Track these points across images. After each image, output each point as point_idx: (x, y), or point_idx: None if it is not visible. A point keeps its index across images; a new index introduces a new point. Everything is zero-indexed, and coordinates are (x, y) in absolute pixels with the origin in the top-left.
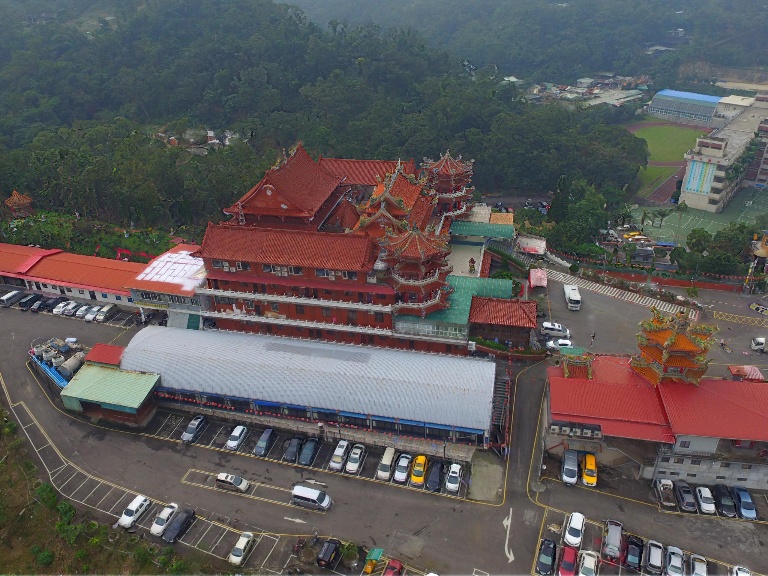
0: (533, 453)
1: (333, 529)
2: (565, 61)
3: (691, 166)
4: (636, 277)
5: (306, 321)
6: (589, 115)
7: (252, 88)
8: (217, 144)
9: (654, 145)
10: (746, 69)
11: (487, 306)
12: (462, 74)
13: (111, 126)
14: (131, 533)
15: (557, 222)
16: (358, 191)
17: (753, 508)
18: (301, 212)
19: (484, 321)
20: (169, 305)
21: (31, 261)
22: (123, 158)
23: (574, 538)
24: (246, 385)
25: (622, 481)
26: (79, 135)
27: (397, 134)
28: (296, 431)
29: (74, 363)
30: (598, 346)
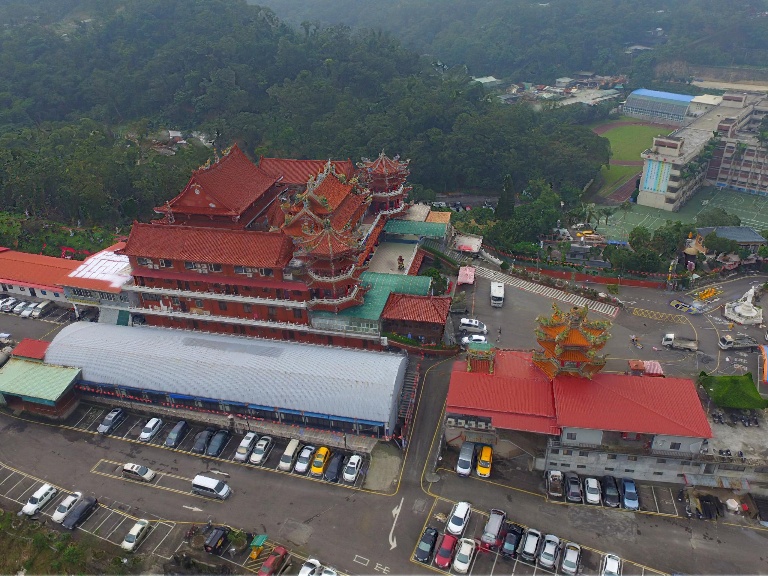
0: (432, 445)
1: (228, 517)
2: (544, 61)
3: (648, 165)
4: (567, 275)
5: (228, 317)
6: (561, 115)
7: (221, 89)
8: (185, 144)
9: (624, 144)
10: (722, 68)
11: (400, 302)
12: (432, 74)
13: (77, 127)
14: (34, 520)
15: (503, 221)
16: (293, 190)
17: (636, 498)
18: (228, 211)
19: (396, 317)
20: (100, 301)
21: None
22: (73, 158)
23: (456, 526)
24: (161, 379)
25: (516, 472)
26: (46, 136)
27: (360, 134)
28: (209, 423)
29: (0, 357)
30: (513, 342)
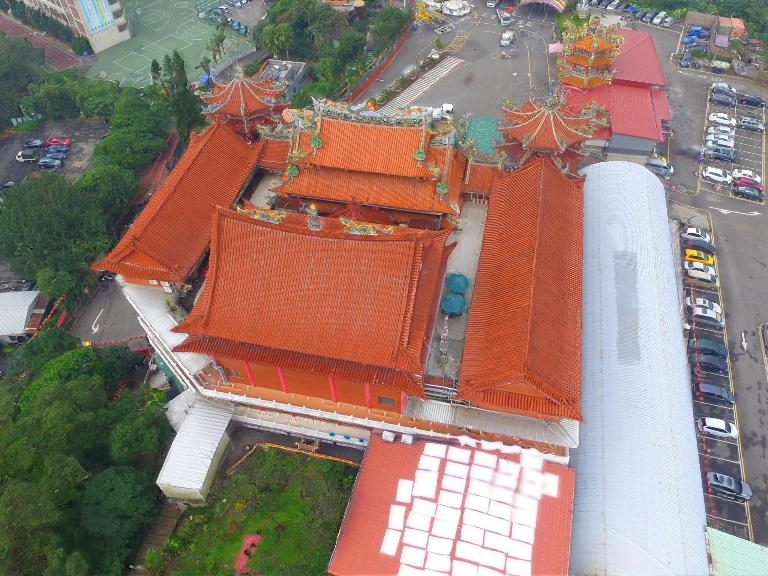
0: None
1: None
2: None
3: (79, 1)
4: (370, 79)
5: None
6: None
7: None
8: None
9: None
10: None
11: None
12: None
13: None
14: None
15: None
16: (287, 202)
17: None
18: (433, 247)
19: None
20: None
21: None
22: None
23: (729, 176)
24: None
25: None
26: None
27: None
28: None
29: None
30: None
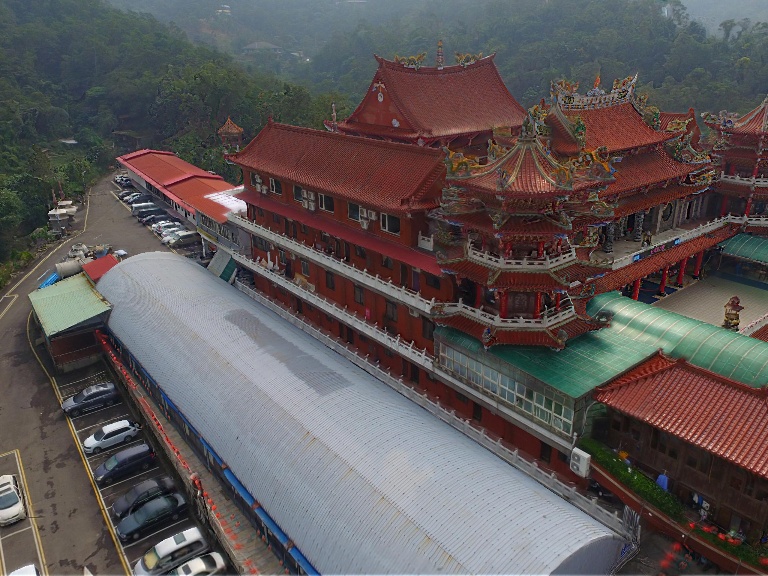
0: None
1: None
2: None
3: None
4: None
5: (325, 300)
6: None
7: None
8: None
9: None
10: None
11: (664, 377)
12: None
13: None
14: None
15: None
16: None
17: None
18: (412, 132)
19: (633, 409)
20: (218, 238)
21: (181, 177)
22: None
23: None
24: (161, 358)
25: None
26: None
27: None
28: (177, 471)
29: (71, 267)
30: None
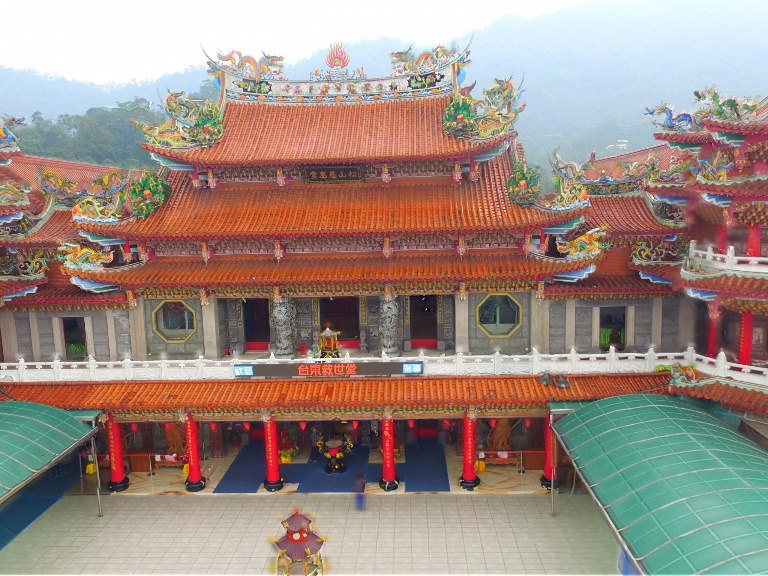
0: None
1: None
2: None
3: None
4: None
5: None
6: None
7: None
8: None
9: None
10: None
11: None
12: None
13: None
14: None
15: None
16: None
17: None
18: None
19: None
20: None
21: None
22: None
23: None
24: None
25: None
26: None
27: None
28: None
29: None
30: None
